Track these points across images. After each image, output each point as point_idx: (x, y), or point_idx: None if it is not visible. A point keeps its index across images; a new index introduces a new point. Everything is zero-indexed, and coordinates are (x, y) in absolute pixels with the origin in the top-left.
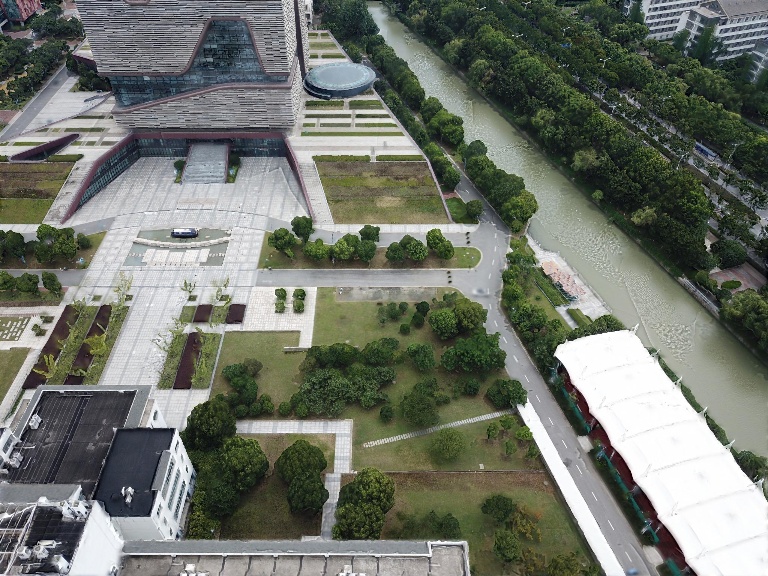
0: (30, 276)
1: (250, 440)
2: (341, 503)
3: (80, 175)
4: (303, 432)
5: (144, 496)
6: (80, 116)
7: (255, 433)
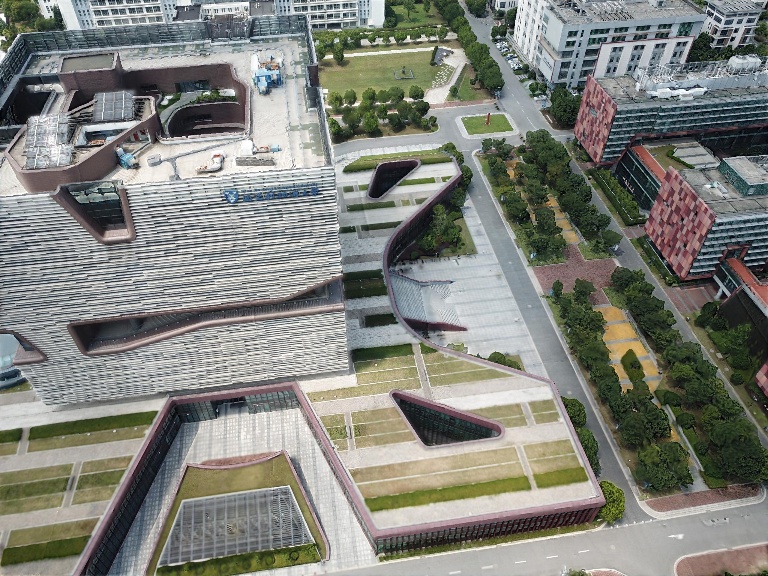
0: None
1: None
2: None
3: None
4: None
5: (181, 10)
6: (394, 225)
7: None
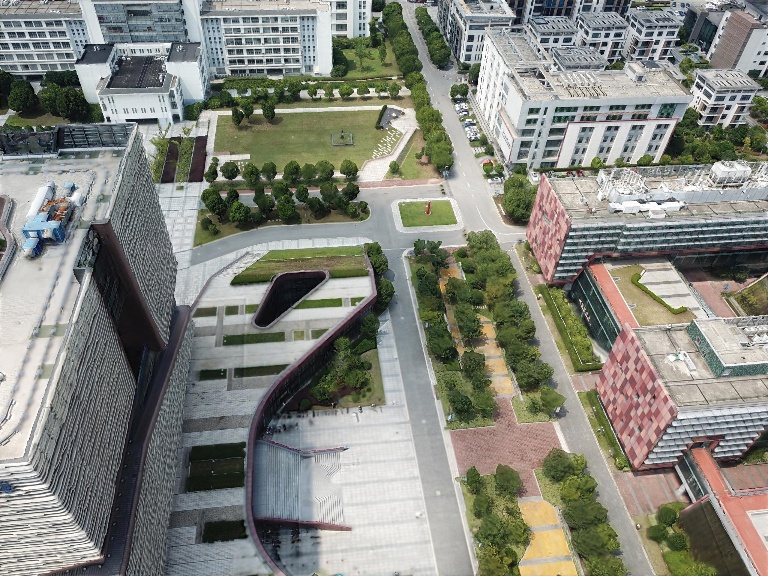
0: (224, 166)
1: (46, 95)
2: (2, 76)
3: (231, 271)
4: (22, 127)
5: None
6: (277, 371)
7: (53, 126)
